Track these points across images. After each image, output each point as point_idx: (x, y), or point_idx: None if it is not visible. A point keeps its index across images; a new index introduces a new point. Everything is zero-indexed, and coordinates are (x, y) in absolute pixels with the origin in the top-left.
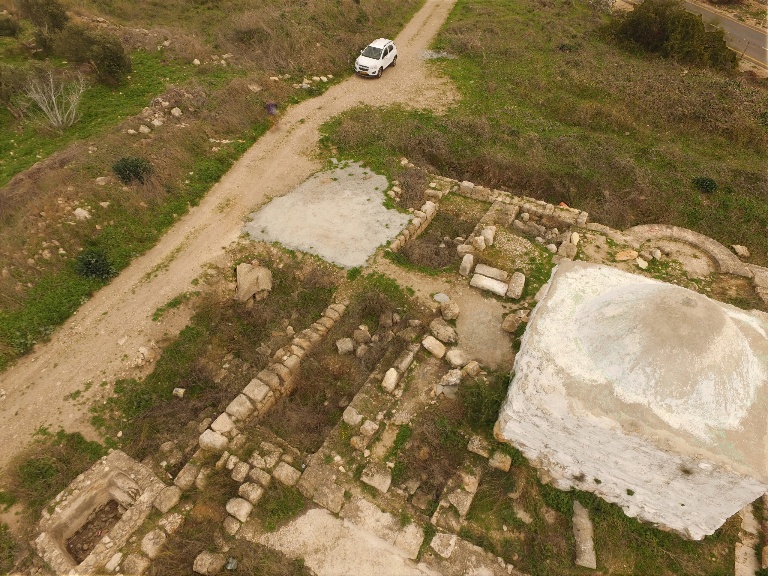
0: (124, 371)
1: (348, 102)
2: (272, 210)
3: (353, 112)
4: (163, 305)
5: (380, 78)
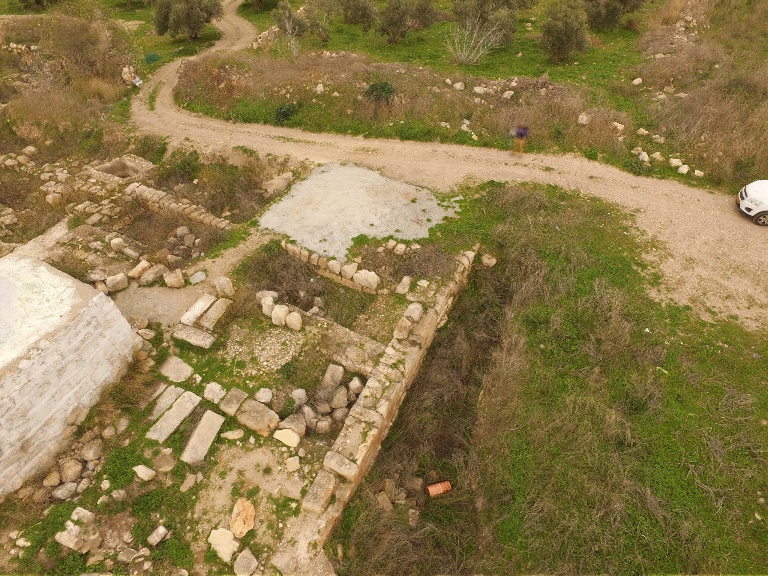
0: None
1: (631, 199)
2: (356, 172)
3: (601, 205)
4: (247, 147)
5: (759, 226)
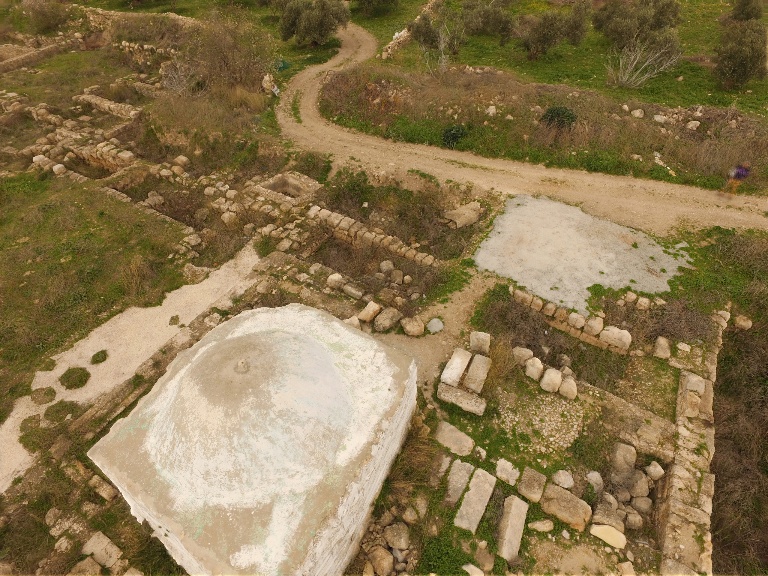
0: (370, 172)
1: None
2: (555, 207)
3: None
4: (422, 172)
5: None
